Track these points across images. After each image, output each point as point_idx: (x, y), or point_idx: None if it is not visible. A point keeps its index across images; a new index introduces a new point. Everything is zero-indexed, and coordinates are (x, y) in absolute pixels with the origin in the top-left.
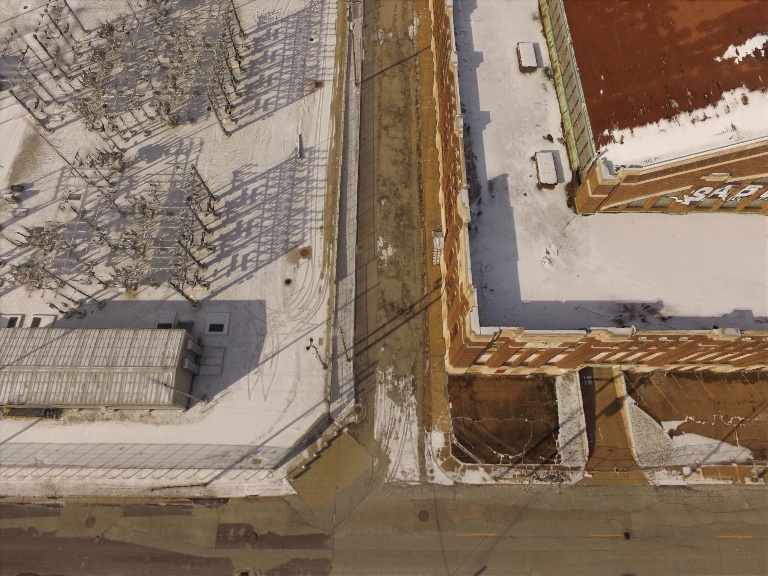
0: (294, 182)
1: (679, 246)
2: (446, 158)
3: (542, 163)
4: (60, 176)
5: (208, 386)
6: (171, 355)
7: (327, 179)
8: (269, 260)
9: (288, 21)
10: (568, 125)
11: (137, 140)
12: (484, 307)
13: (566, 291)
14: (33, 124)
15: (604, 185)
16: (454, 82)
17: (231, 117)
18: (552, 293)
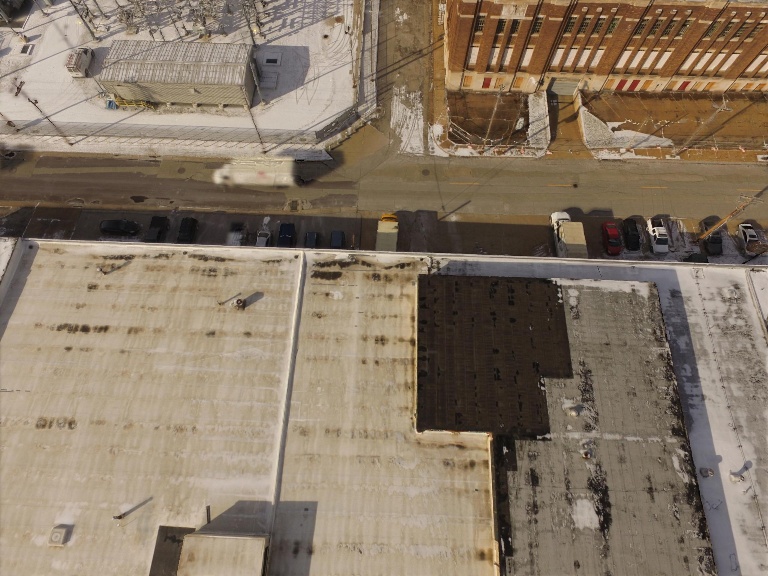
0: None
1: None
2: None
3: None
4: None
5: (266, 95)
6: (242, 57)
7: None
8: (311, 23)
9: None
10: None
11: None
12: None
13: None
14: None
15: None
16: None
17: None
18: None
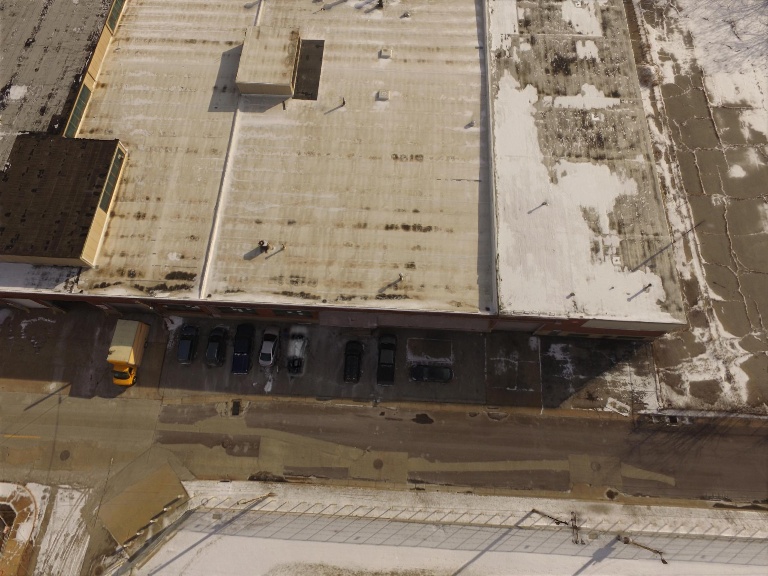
0: None
1: None
2: None
3: None
4: None
5: None
6: None
7: None
8: None
9: None
10: None
11: None
12: None
13: None
14: None
15: None
16: None
17: None
18: None
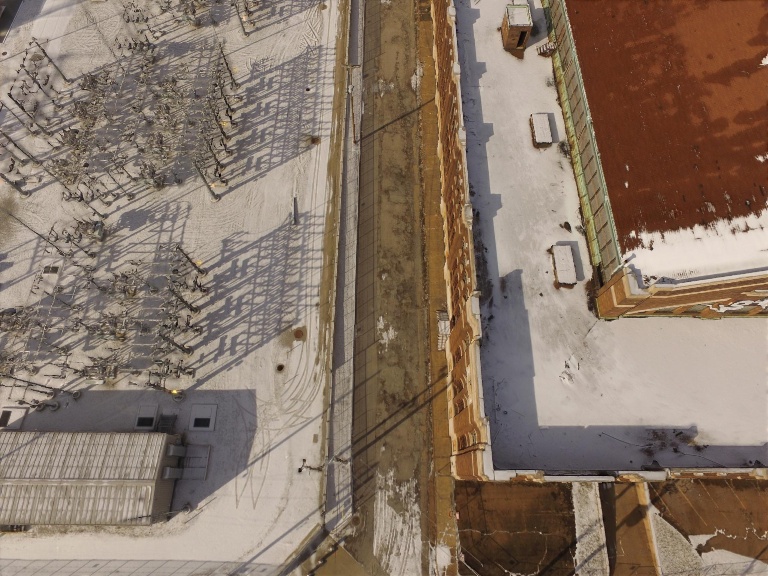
0: (288, 252)
1: (713, 358)
2: (452, 237)
3: (560, 259)
4: (36, 246)
5: (192, 491)
6: (150, 465)
7: (323, 249)
8: (260, 343)
9: (283, 69)
10: (587, 212)
11: (120, 204)
12: (497, 434)
13: (588, 414)
14: (8, 186)
15: (632, 298)
16: (462, 161)
17: (221, 179)
18: (573, 416)
